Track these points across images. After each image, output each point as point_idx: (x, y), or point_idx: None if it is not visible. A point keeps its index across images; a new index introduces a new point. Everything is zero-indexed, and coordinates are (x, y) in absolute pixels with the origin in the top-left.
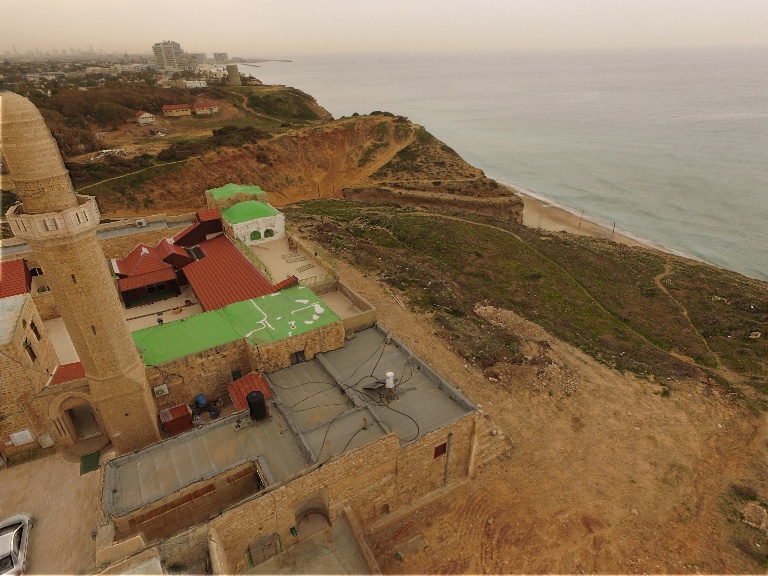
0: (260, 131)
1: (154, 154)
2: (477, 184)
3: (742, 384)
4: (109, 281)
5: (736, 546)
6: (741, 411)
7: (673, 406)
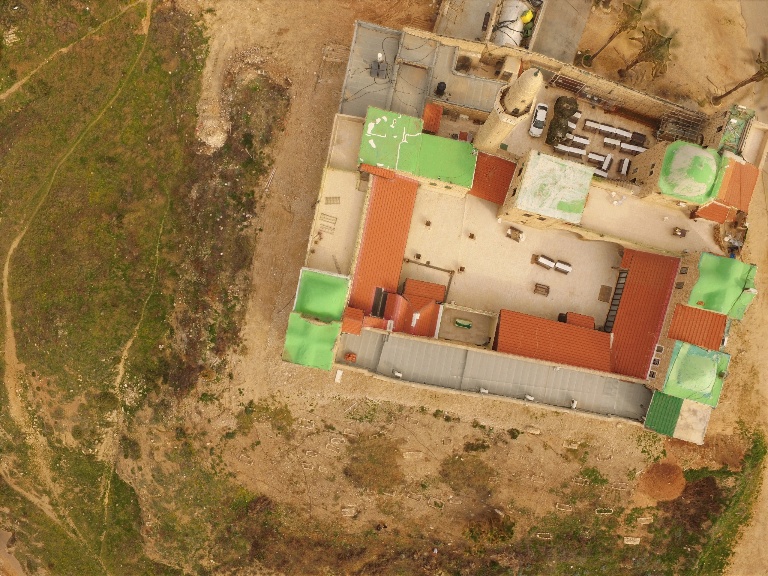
0: None
1: None
2: None
3: None
4: None
5: None
6: None
7: (220, 3)
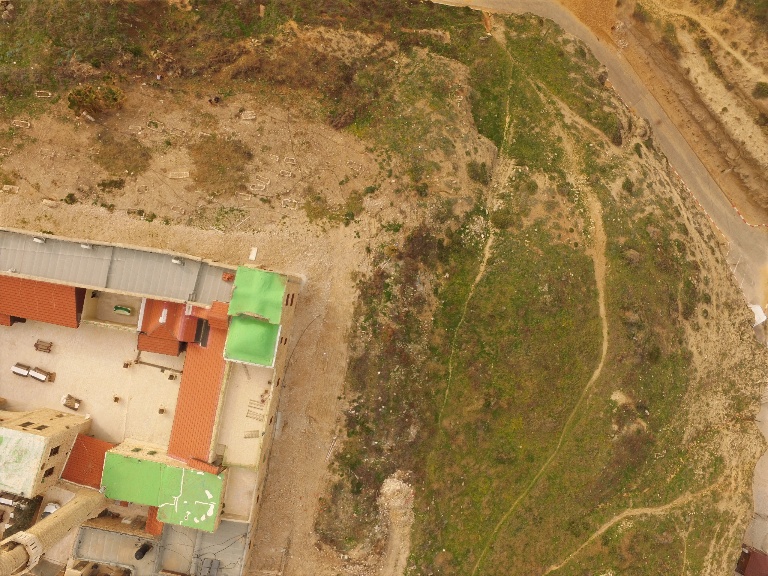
0: None
1: None
2: None
3: None
4: None
5: None
6: None
7: None
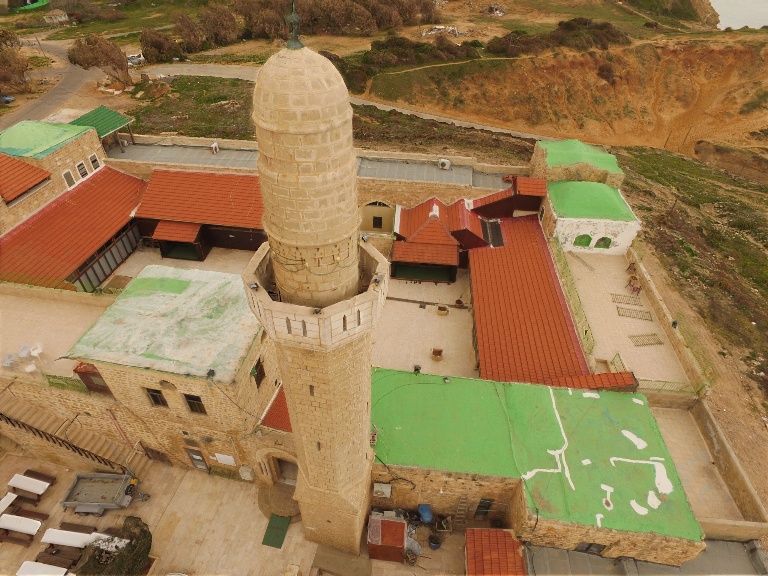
0: (619, 32)
1: (484, 41)
2: None
3: None
4: (363, 392)
5: None
6: None
7: None
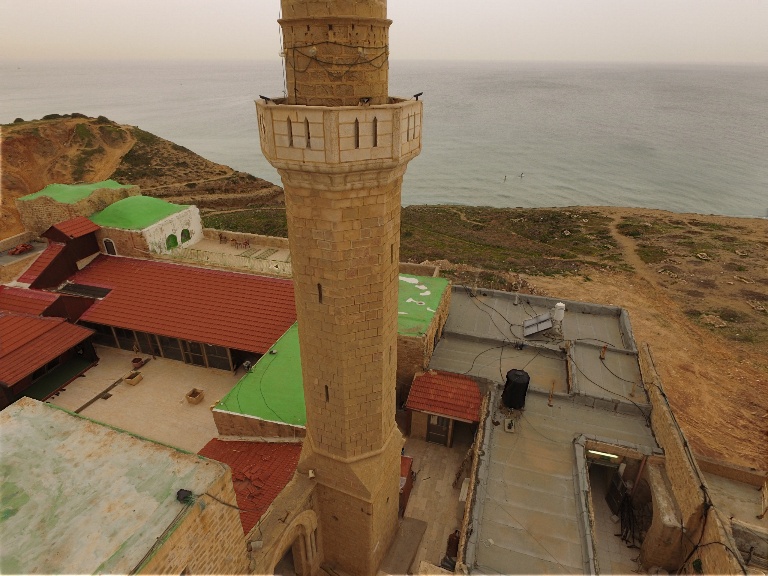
0: None
1: None
2: (235, 180)
3: (603, 260)
4: None
5: (734, 340)
6: (626, 274)
7: (602, 284)
